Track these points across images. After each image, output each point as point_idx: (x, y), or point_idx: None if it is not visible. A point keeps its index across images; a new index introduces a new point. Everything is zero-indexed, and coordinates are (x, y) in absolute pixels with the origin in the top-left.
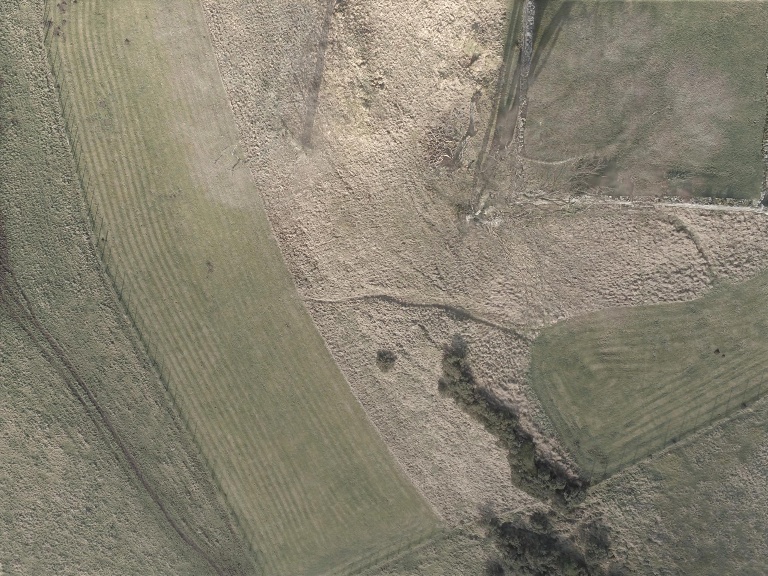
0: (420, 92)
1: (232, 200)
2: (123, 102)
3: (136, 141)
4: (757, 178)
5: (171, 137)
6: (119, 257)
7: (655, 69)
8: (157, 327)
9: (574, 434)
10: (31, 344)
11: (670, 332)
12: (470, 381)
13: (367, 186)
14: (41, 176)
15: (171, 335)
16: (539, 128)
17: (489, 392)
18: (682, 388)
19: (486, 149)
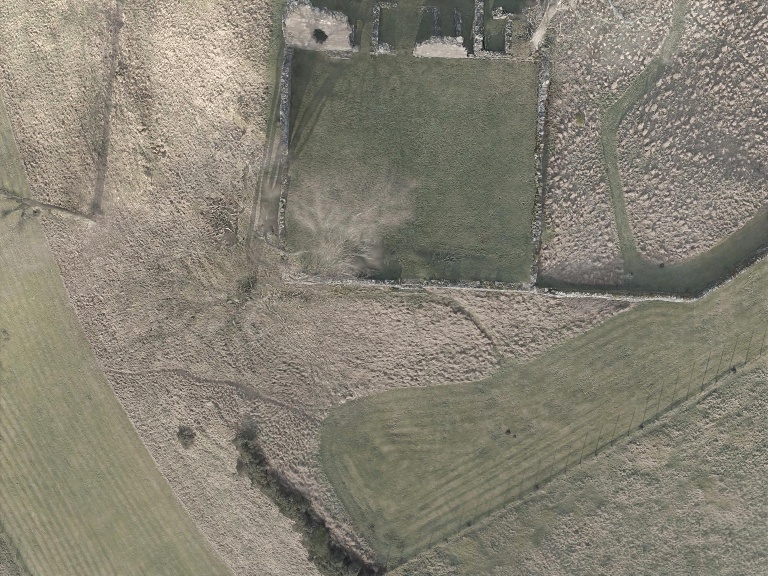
0: (199, 162)
1: (27, 265)
2: None
3: None
4: (526, 261)
5: None
6: None
7: (424, 147)
8: None
9: (368, 518)
10: None
11: (460, 413)
12: (262, 462)
13: (156, 256)
14: None
15: None
16: (301, 208)
17: (281, 474)
18: (475, 470)
19: (253, 227)
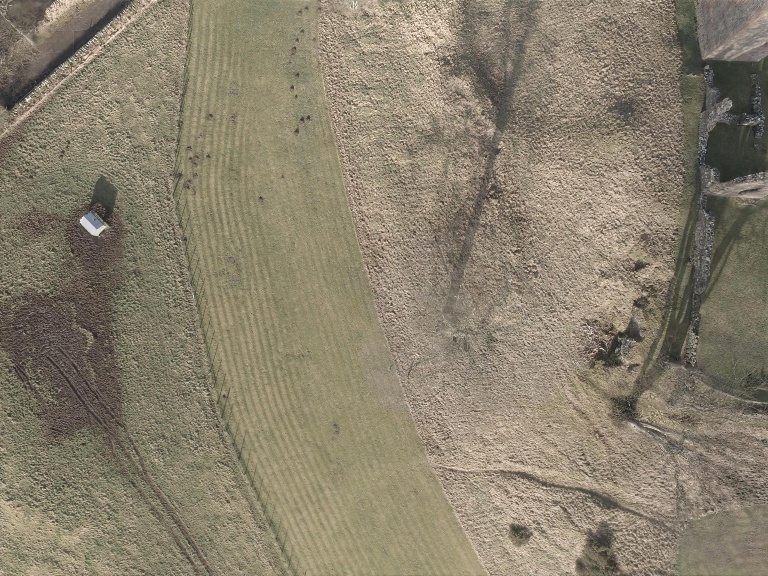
0: (578, 286)
1: (364, 364)
2: (253, 259)
3: (265, 299)
4: None
5: (302, 297)
6: (241, 415)
7: None
8: (276, 487)
9: None
10: (140, 501)
11: None
12: (614, 568)
13: (513, 366)
14: (162, 329)
15: (291, 495)
16: (710, 344)
17: None
18: None
19: (653, 356)
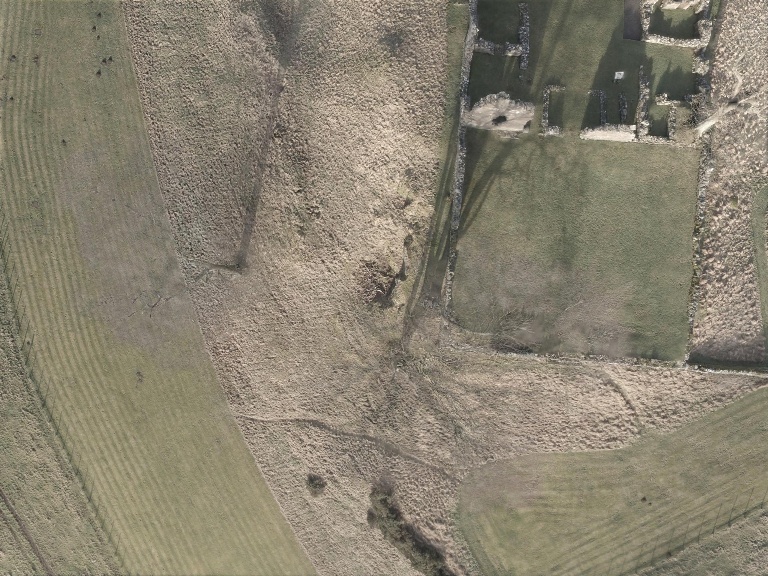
0: (355, 226)
1: (165, 310)
2: (56, 203)
3: (68, 244)
4: (682, 340)
5: (105, 242)
6: (45, 362)
7: (585, 225)
8: (82, 435)
9: None
10: None
11: (598, 479)
12: (398, 517)
13: (301, 311)
14: None
15: (96, 444)
16: (468, 281)
17: (416, 530)
18: (609, 534)
19: (416, 295)
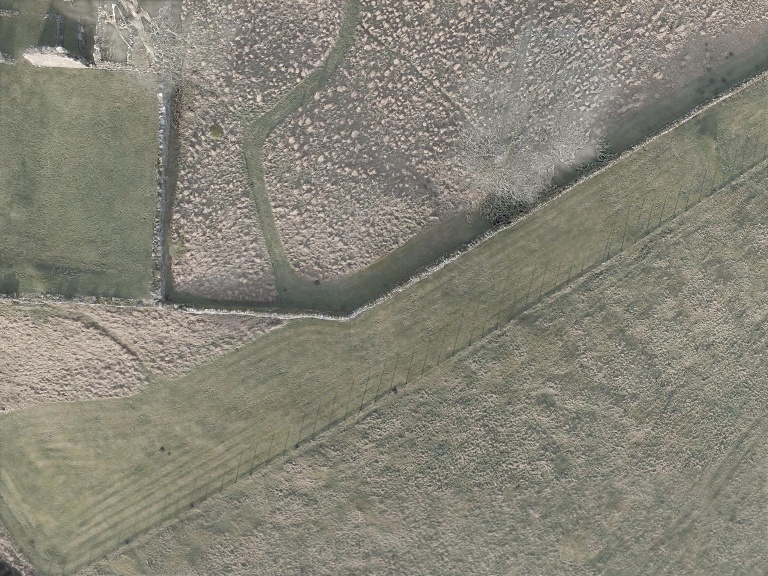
0: None
1: None
2: None
3: None
4: (146, 277)
5: None
6: None
7: (47, 159)
8: None
9: (28, 533)
10: None
11: (112, 429)
12: None
13: None
14: None
15: None
16: None
17: None
18: (131, 487)
19: None
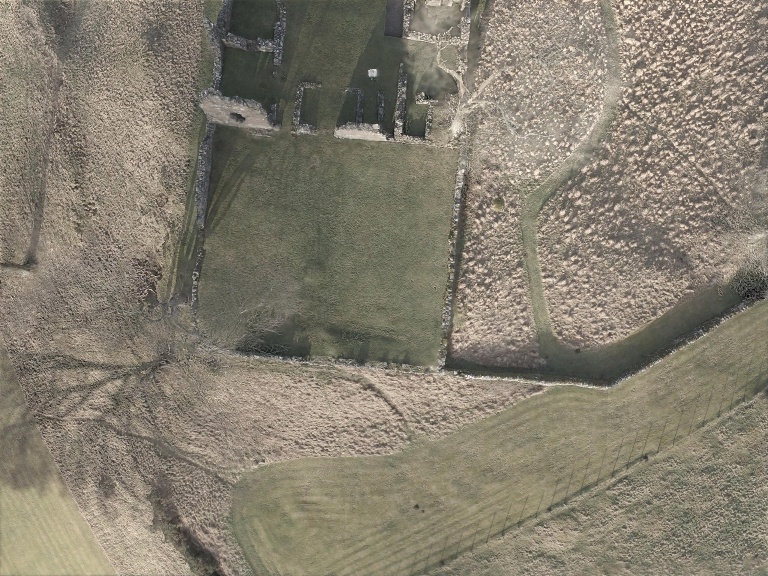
0: (126, 223)
1: None
2: None
3: None
4: (435, 345)
5: None
6: None
7: (341, 226)
8: None
9: None
10: None
11: (369, 485)
12: (175, 520)
13: (85, 309)
14: None
15: None
16: (215, 281)
17: (192, 533)
18: (382, 542)
19: (170, 295)
